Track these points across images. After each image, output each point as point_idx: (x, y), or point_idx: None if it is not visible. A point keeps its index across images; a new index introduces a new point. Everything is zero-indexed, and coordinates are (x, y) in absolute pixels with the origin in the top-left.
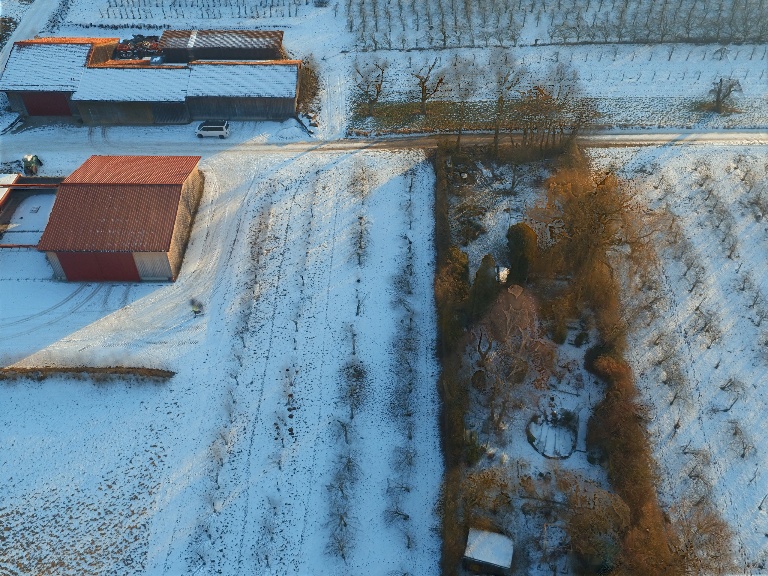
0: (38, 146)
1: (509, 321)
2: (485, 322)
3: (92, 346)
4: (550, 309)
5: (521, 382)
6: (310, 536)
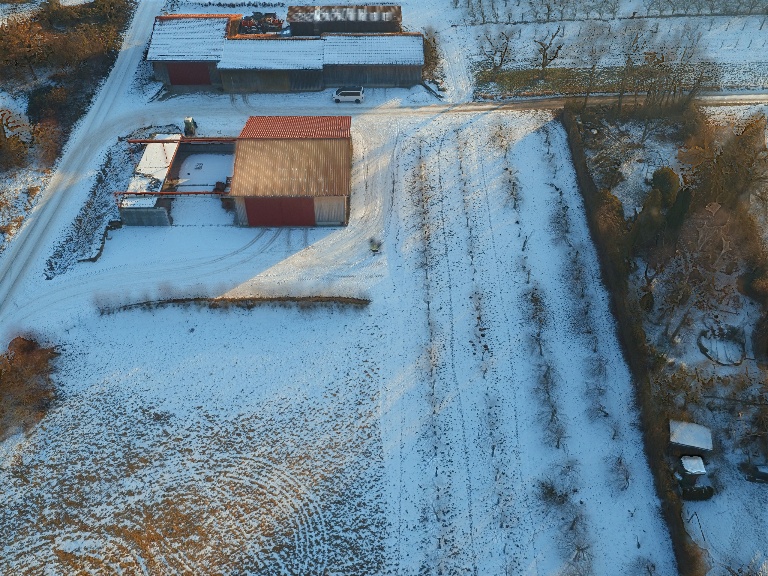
0: (187, 111)
1: (702, 237)
2: (641, 255)
3: (288, 280)
4: None
5: (685, 304)
6: (524, 431)
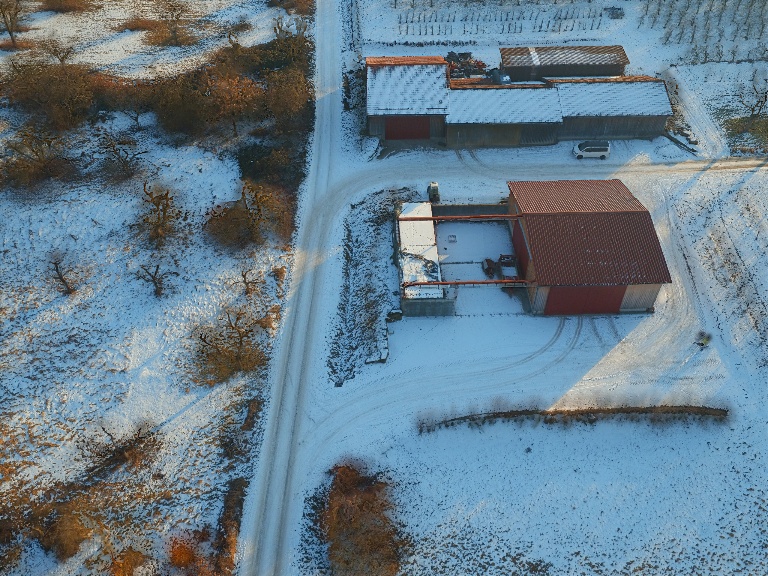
0: (416, 172)
1: None
2: None
3: (620, 384)
4: None
5: None
6: None
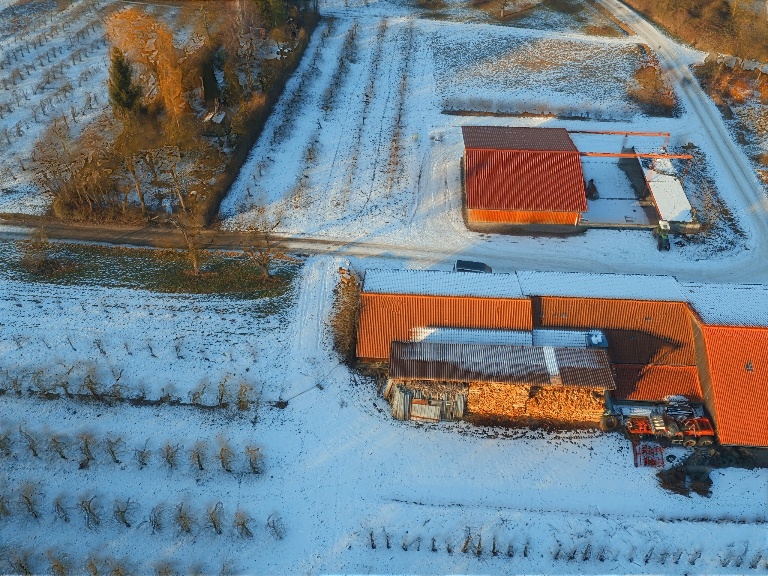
0: (690, 278)
1: None
2: None
3: None
4: None
5: None
6: None
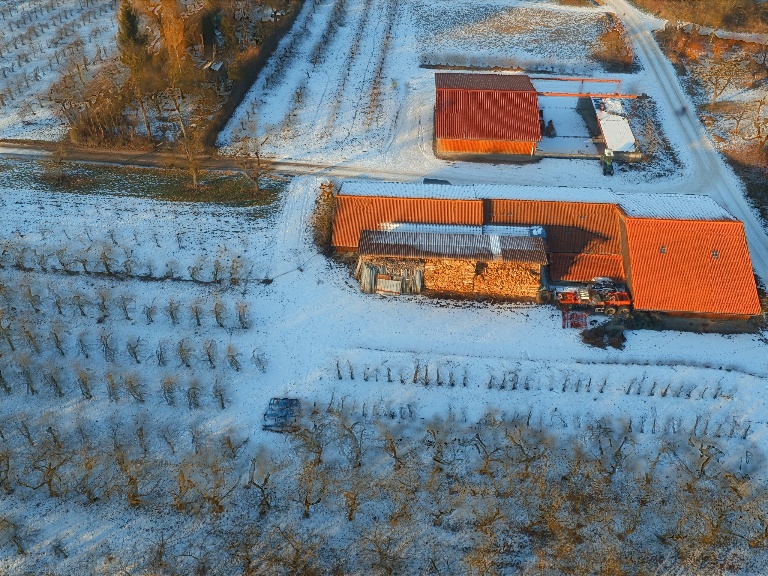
0: None
1: None
2: None
3: None
4: None
5: None
6: (345, 36)
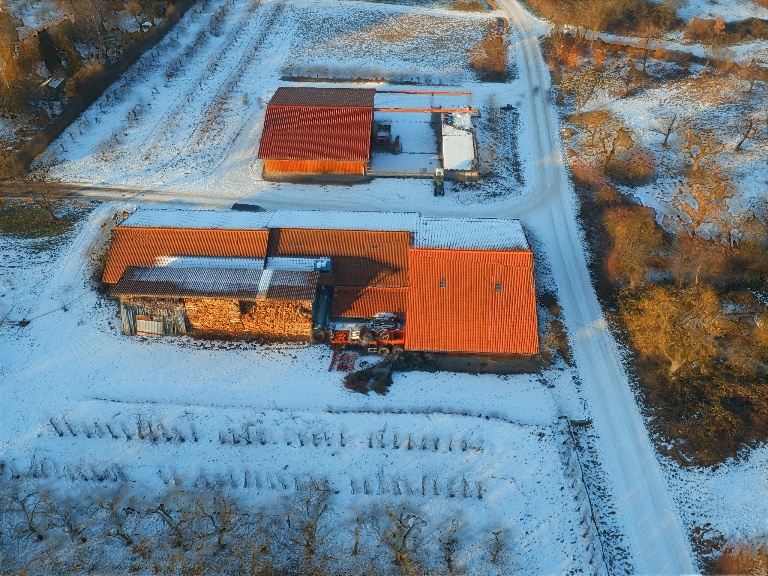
0: None
1: None
2: None
3: None
4: (30, 83)
5: None
6: None
